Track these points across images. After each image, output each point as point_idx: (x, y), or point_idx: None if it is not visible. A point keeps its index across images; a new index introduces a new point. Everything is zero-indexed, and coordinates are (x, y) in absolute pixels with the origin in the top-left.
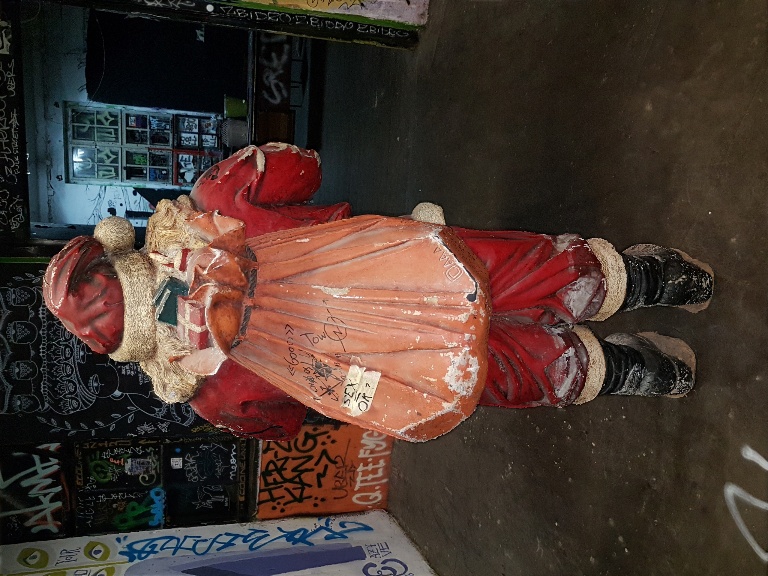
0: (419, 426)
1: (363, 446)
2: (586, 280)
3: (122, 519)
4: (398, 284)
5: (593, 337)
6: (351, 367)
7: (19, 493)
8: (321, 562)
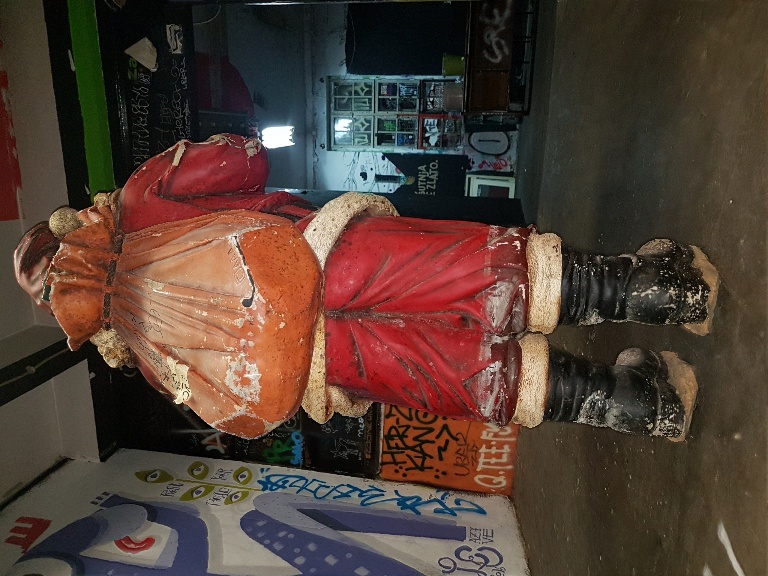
0: (226, 424)
1: (486, 428)
2: (507, 285)
3: (270, 453)
4: (201, 283)
5: (543, 352)
6: (168, 358)
7: (196, 416)
8: (418, 532)
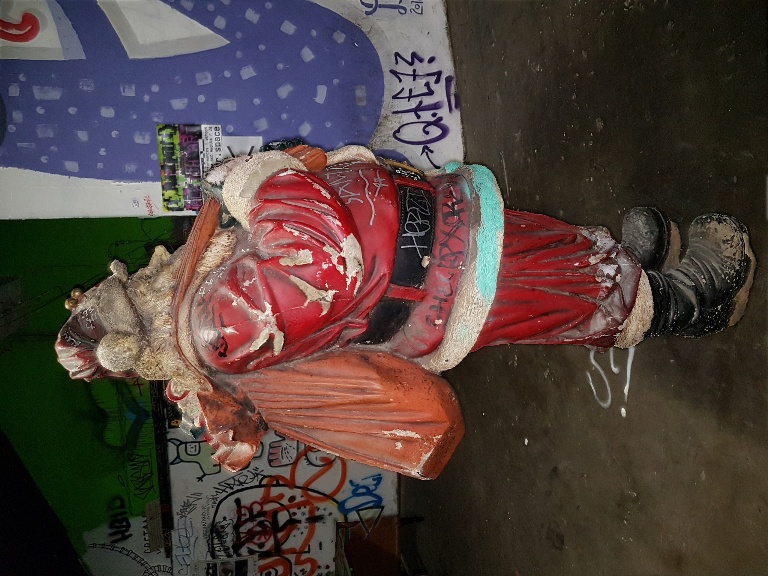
0: None
1: None
2: None
3: None
4: None
5: None
6: None
7: None
8: None
